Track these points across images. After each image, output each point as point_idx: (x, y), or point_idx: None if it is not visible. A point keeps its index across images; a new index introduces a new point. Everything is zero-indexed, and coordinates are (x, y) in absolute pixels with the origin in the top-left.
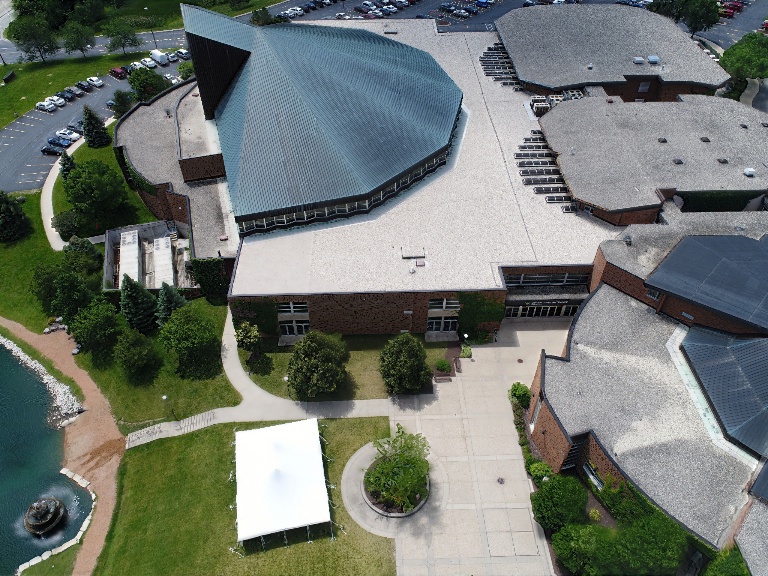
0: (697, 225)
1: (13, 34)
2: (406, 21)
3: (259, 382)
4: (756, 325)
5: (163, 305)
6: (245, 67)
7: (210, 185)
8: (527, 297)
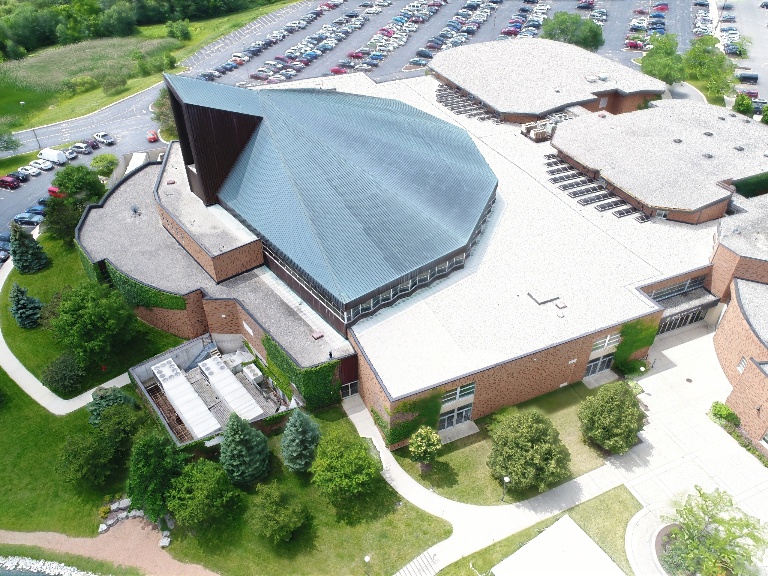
0: None
1: None
2: (336, 77)
3: (454, 496)
4: None
5: (296, 439)
6: (259, 135)
7: (251, 280)
8: (664, 313)
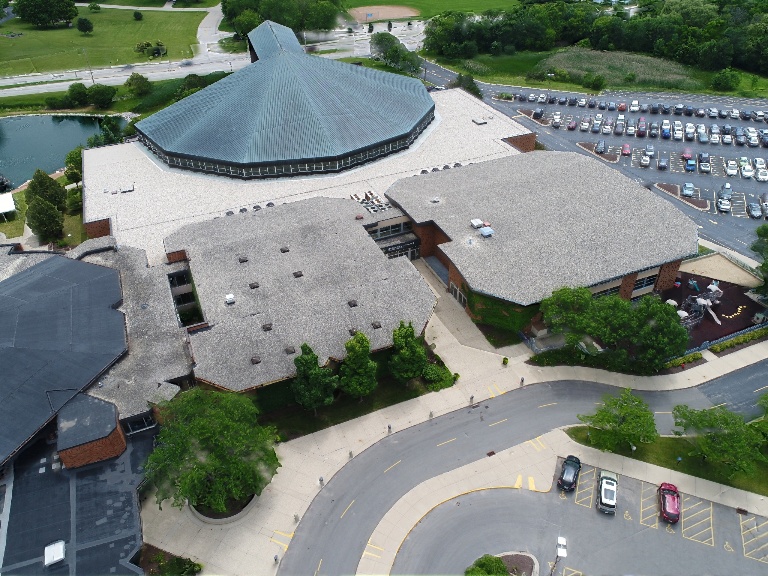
0: (148, 282)
1: (371, 40)
2: (512, 123)
3: None
4: None
5: None
6: None
7: None
8: None
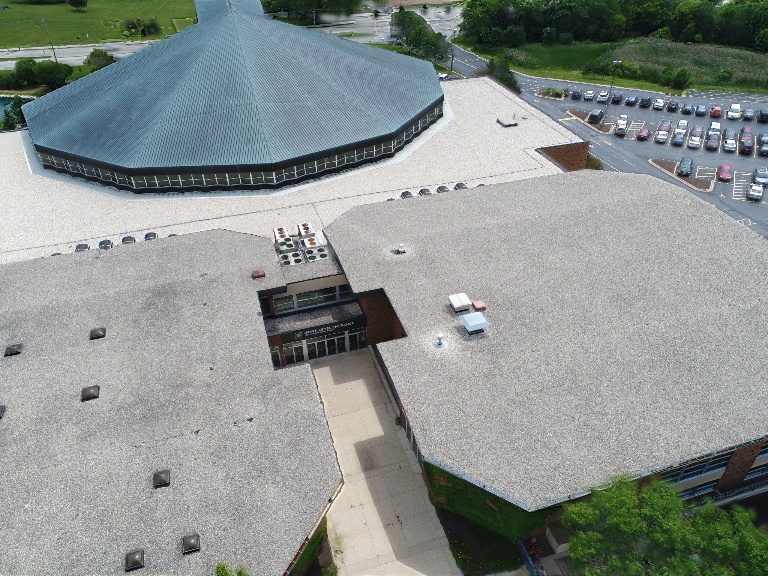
0: None
1: (391, 20)
2: (554, 126)
3: None
4: None
5: None
6: None
7: None
8: None
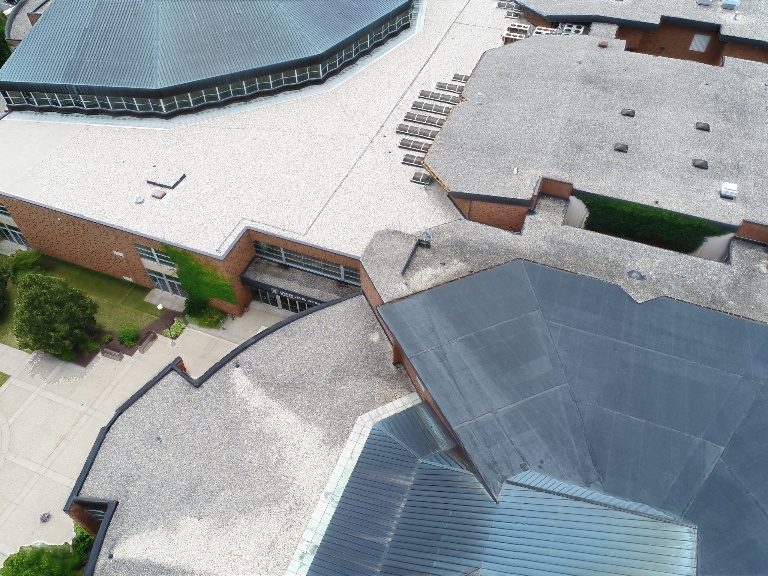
0: (568, 249)
1: None
2: None
3: None
4: (459, 441)
5: None
6: None
7: None
8: (280, 282)
